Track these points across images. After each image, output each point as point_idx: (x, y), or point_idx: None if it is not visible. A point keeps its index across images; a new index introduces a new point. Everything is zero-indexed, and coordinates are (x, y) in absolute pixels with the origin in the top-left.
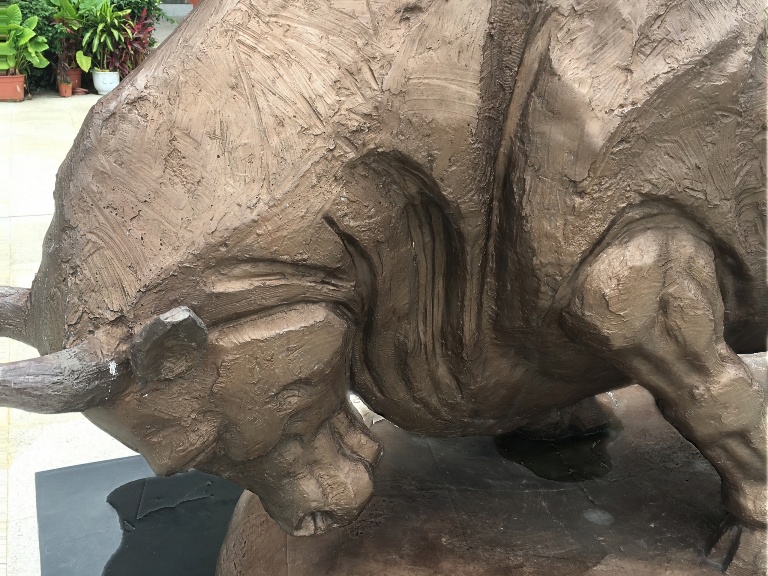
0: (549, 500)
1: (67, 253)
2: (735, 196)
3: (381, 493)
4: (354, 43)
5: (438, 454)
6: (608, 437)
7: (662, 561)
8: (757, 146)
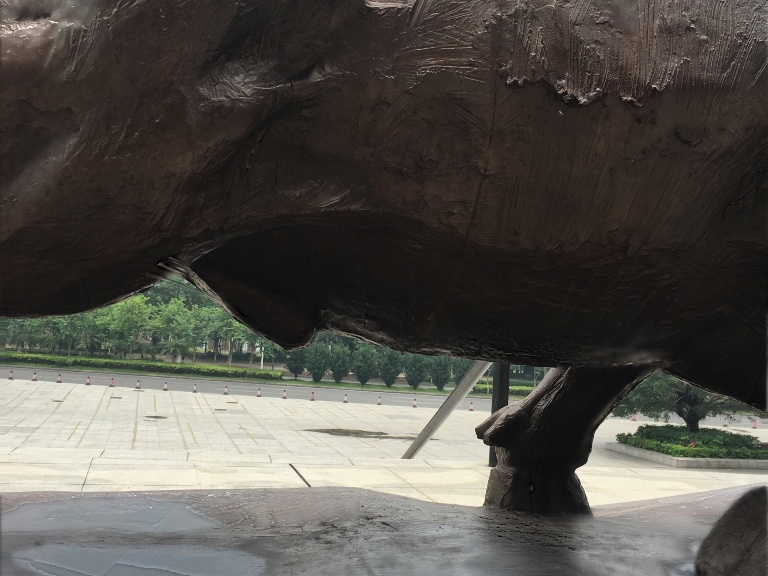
0: None
1: None
2: None
3: None
4: None
5: None
6: None
7: None
8: None
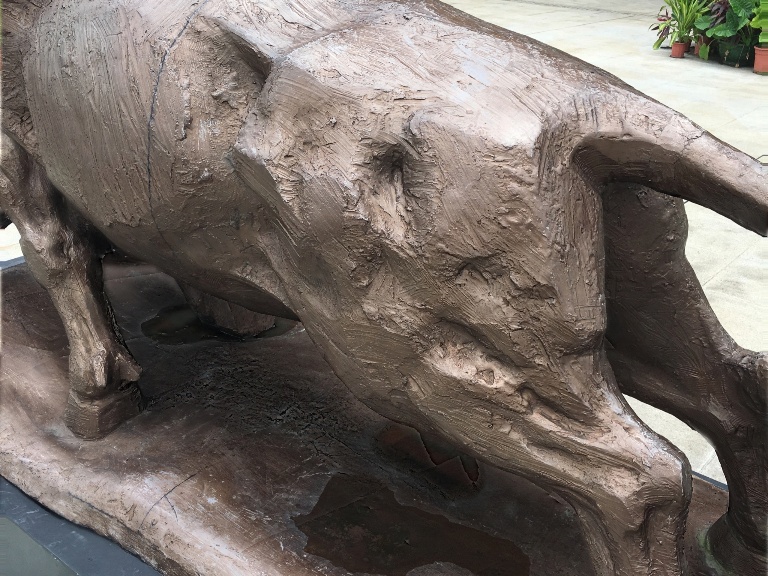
0: None
1: None
2: (10, 108)
3: None
4: None
5: (120, 280)
6: (225, 339)
7: (65, 375)
8: (19, 77)
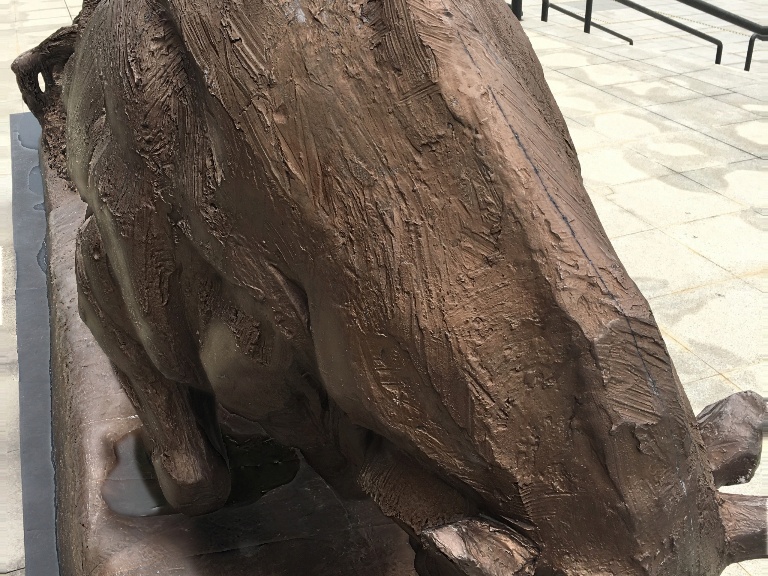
0: None
1: (699, 468)
2: None
3: (380, 572)
4: (554, 125)
5: (280, 537)
6: (222, 430)
7: None
8: None
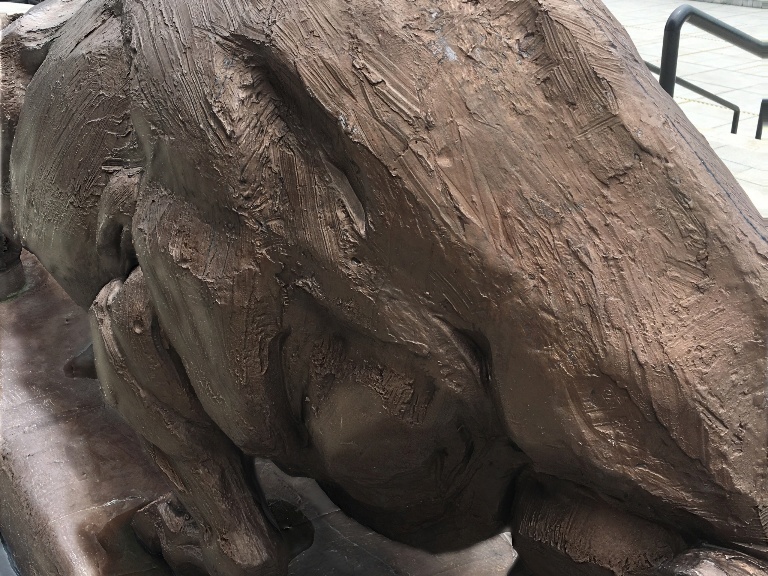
0: (360, 532)
1: None
2: None
3: None
4: None
5: None
6: None
7: None
8: None
